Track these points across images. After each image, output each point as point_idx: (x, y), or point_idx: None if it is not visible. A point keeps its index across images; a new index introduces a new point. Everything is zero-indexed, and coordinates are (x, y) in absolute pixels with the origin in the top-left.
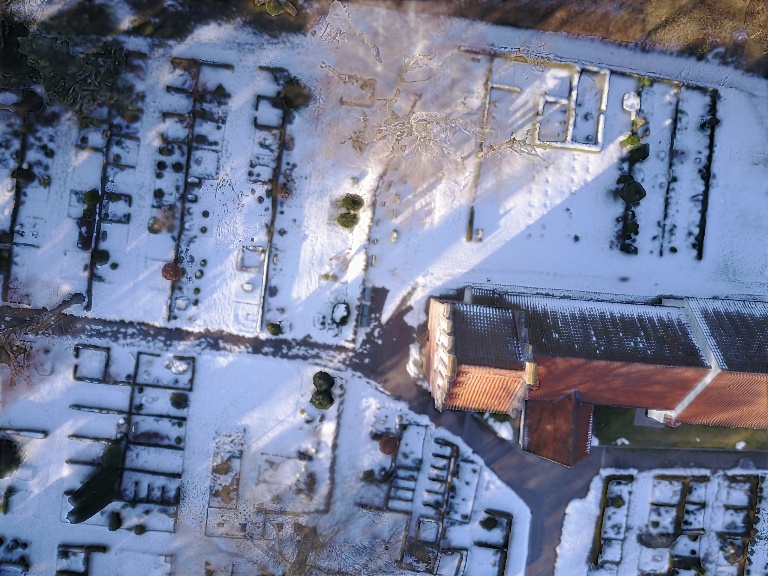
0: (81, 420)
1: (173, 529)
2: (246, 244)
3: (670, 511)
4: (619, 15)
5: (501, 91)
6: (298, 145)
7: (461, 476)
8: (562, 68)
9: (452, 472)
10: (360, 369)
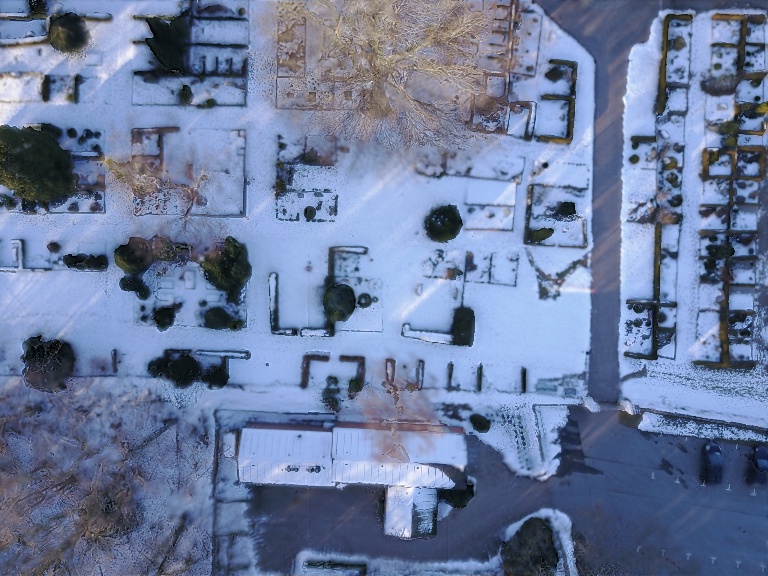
0: (145, 2)
1: (244, 101)
2: None
3: (731, 53)
4: None
5: None
6: None
7: (523, 28)
8: None
9: (514, 20)
10: None
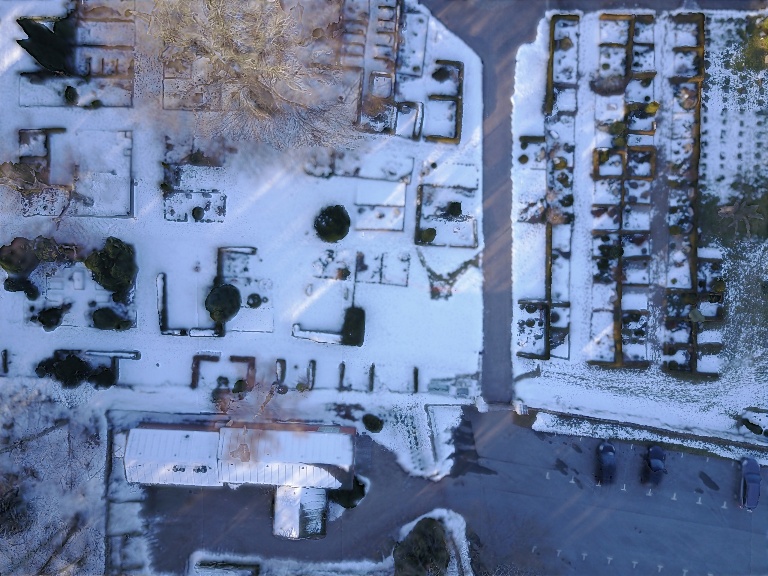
0: (32, 4)
1: (130, 103)
2: None
3: (620, 53)
4: None
5: None
6: None
7: (409, 29)
8: None
9: (399, 21)
10: None
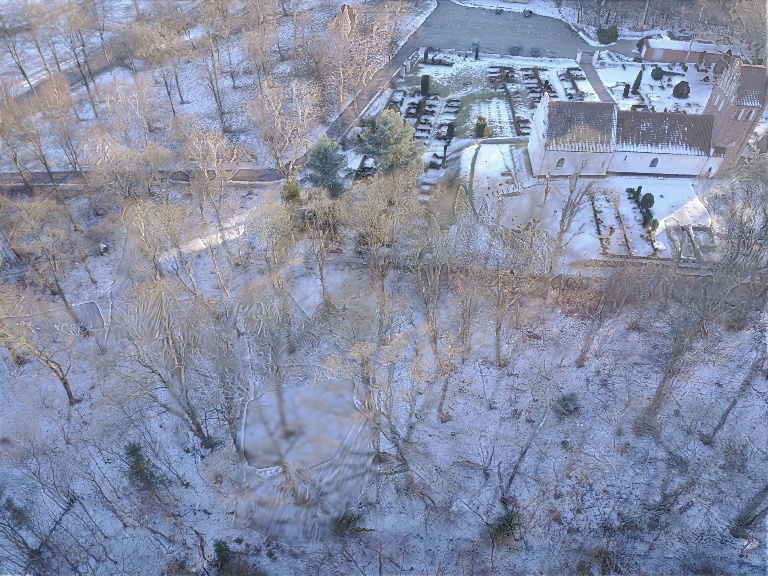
0: None
1: None
2: None
3: None
4: None
5: None
6: None
7: None
8: None
9: None
10: None
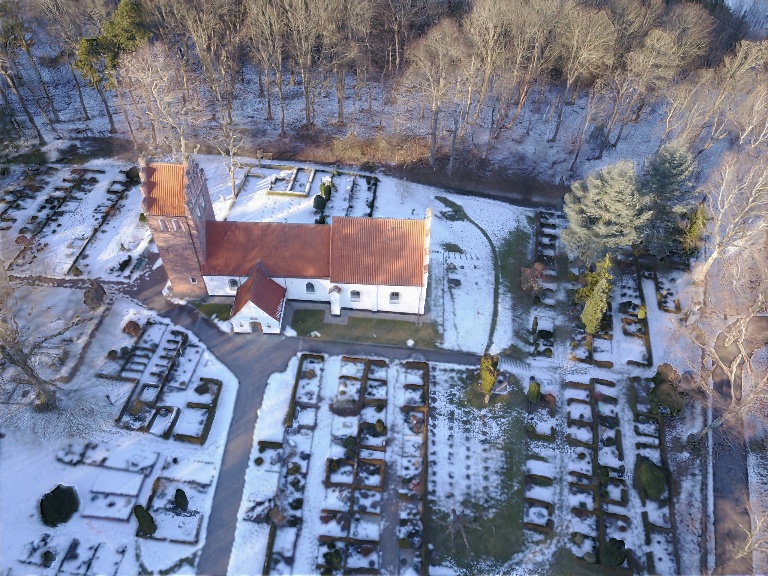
0: None
1: None
2: (78, 237)
3: (356, 385)
4: (318, 149)
5: (253, 177)
6: (129, 199)
7: (186, 356)
8: (289, 170)
9: (179, 349)
10: (129, 293)
